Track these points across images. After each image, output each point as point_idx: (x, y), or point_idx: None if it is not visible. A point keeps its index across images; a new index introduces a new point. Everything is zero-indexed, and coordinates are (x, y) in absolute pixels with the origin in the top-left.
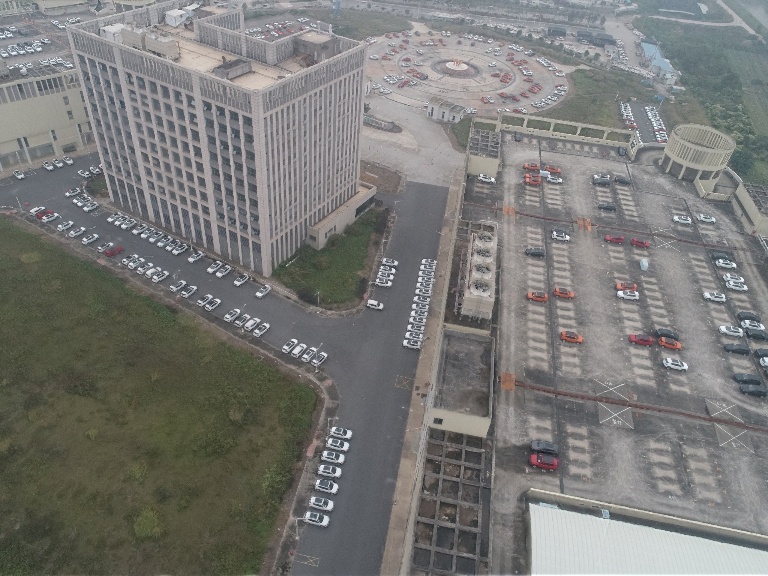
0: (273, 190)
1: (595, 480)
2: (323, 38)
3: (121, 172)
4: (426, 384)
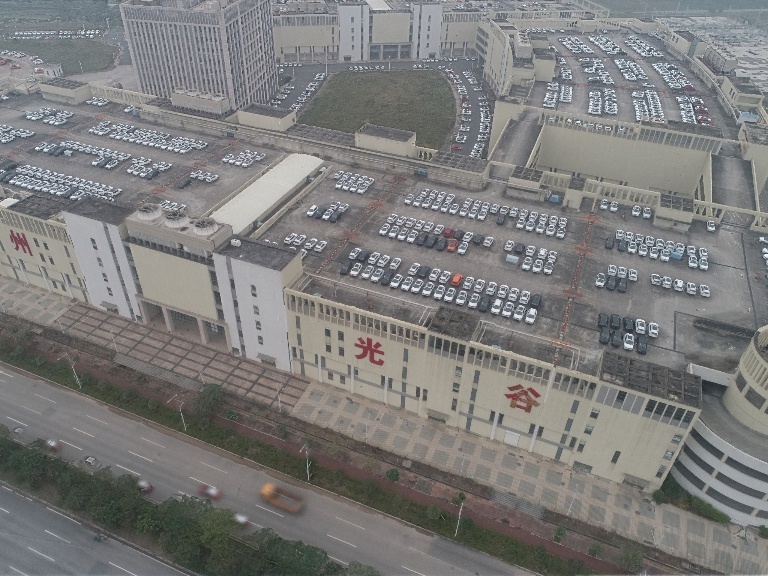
0: None
1: None
2: None
3: None
4: (318, 62)
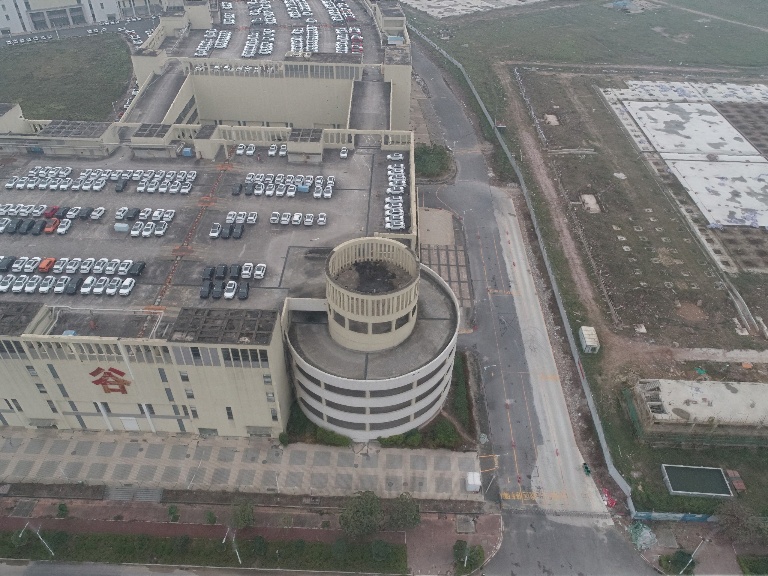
0: None
1: None
2: None
3: None
4: None
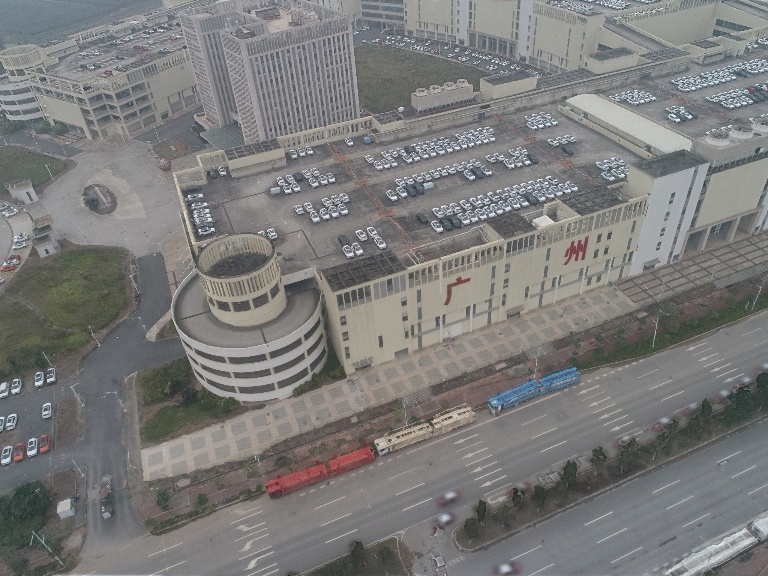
0: None
1: None
2: (197, 15)
3: None
4: None
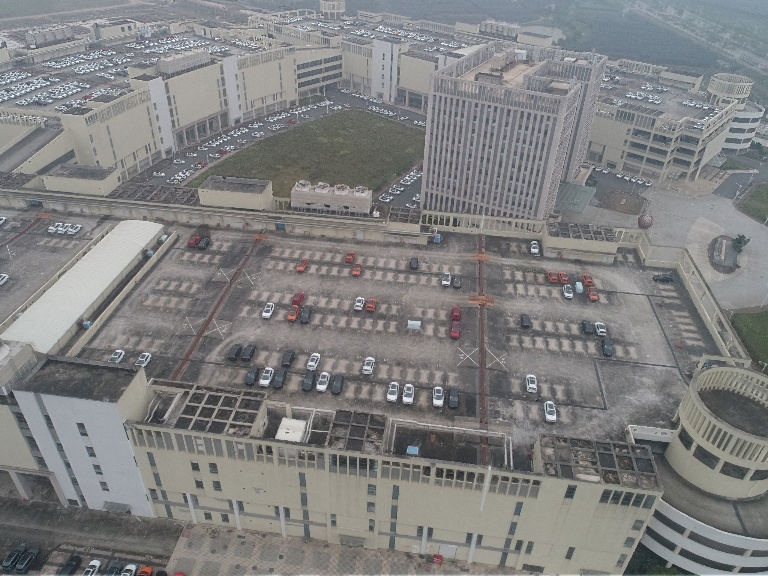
0: (435, 153)
1: (178, 260)
2: None
3: None
4: None
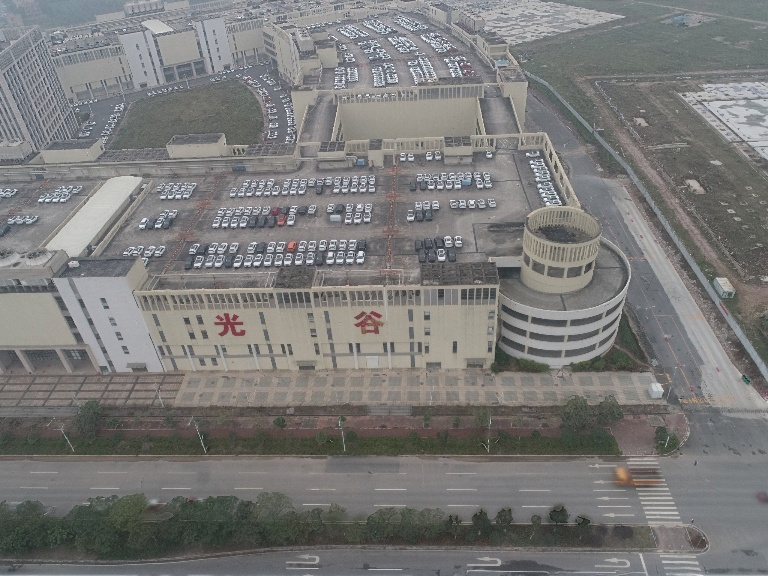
0: None
1: None
2: None
3: (39, 144)
4: None
